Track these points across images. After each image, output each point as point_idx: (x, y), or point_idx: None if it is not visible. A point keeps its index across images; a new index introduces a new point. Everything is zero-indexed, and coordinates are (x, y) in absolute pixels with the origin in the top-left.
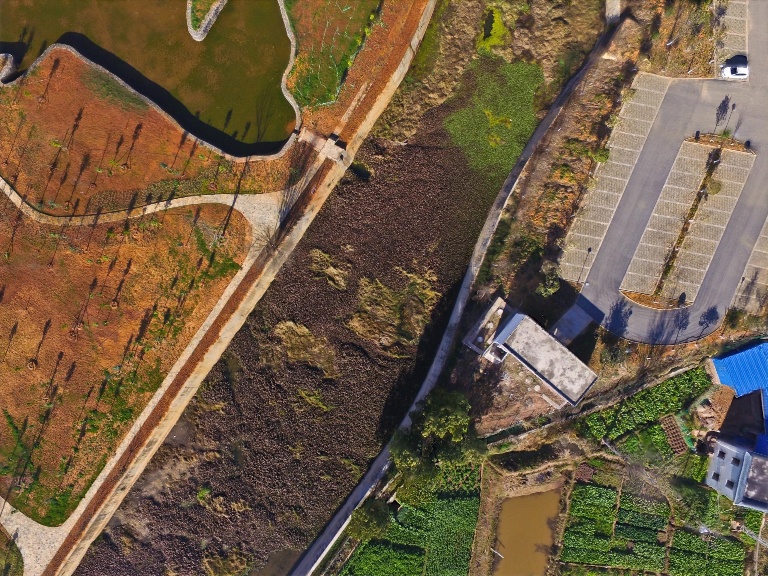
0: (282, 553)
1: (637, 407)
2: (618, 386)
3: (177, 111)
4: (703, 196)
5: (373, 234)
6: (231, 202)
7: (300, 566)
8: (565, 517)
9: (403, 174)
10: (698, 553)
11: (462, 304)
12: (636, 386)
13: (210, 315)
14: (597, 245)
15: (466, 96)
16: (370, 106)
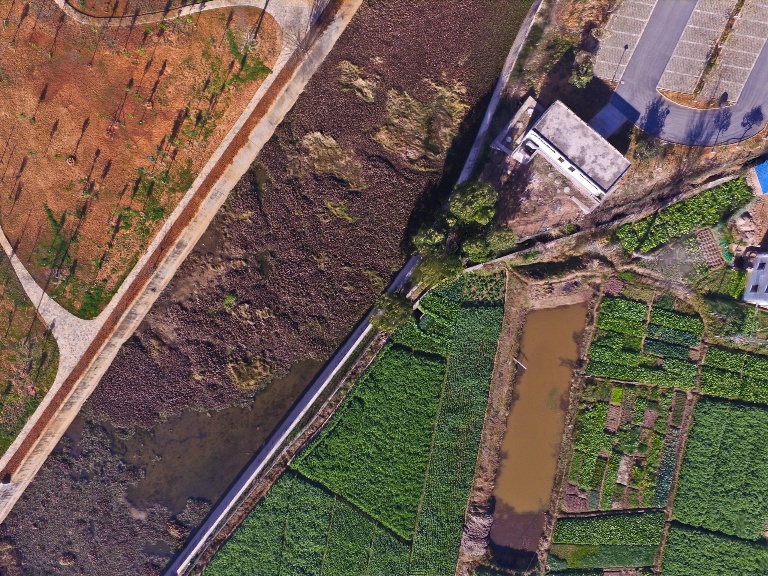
0: (304, 363)
1: (671, 219)
2: (652, 193)
3: None
4: None
5: (403, 46)
6: (263, 5)
7: (322, 375)
8: (592, 330)
9: None
10: (732, 372)
11: (491, 112)
12: (671, 195)
13: (240, 118)
14: (634, 42)
15: None
16: None
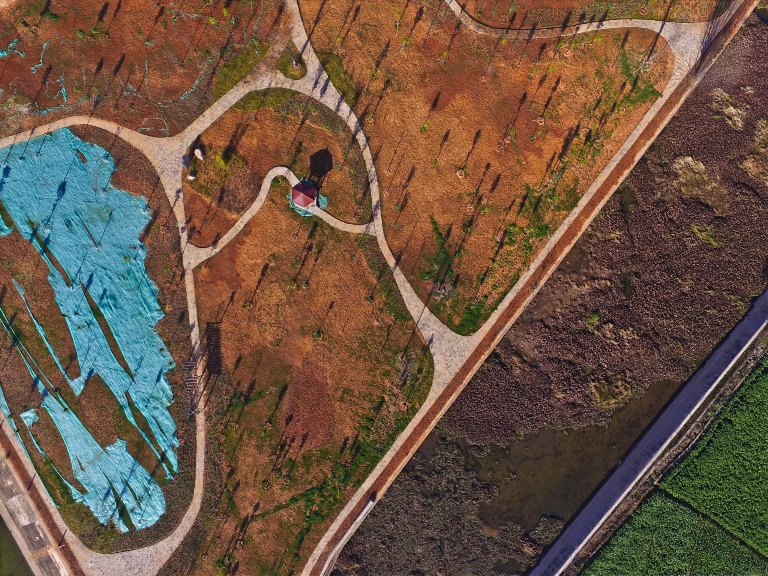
0: (661, 384)
1: None
2: None
3: None
4: None
5: None
6: (659, 28)
7: (681, 396)
8: None
9: None
10: None
11: None
12: None
13: (628, 139)
14: None
15: None
16: None
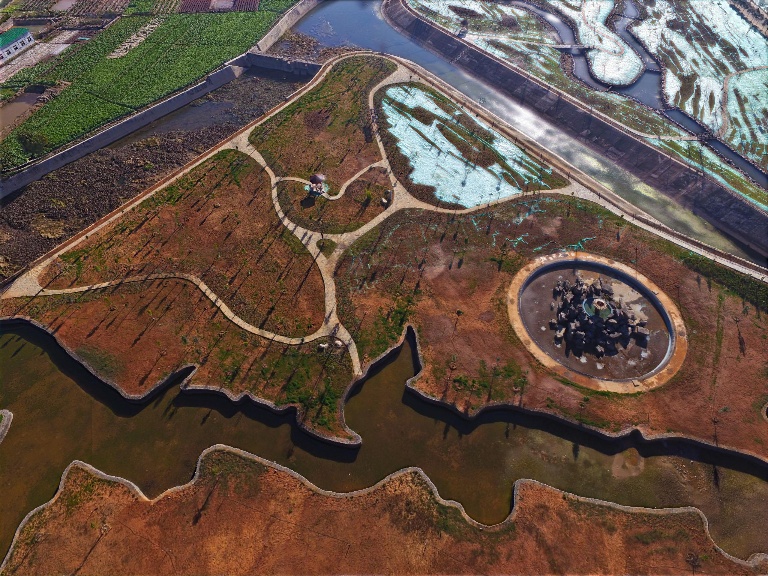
0: None
1: None
2: None
3: (62, 358)
4: None
5: None
6: None
7: (106, 143)
8: None
9: None
10: None
11: None
12: None
13: (94, 232)
14: None
15: None
16: None
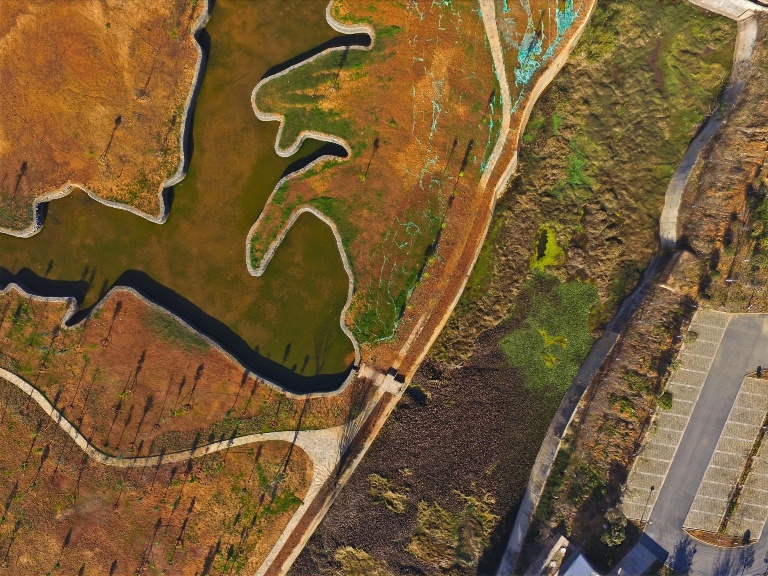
0: None
1: None
2: None
3: (236, 344)
4: (766, 432)
5: (431, 457)
6: (292, 439)
7: None
8: None
9: (460, 397)
10: None
11: (522, 532)
12: None
13: (272, 550)
14: (660, 483)
15: (521, 317)
16: (428, 338)
